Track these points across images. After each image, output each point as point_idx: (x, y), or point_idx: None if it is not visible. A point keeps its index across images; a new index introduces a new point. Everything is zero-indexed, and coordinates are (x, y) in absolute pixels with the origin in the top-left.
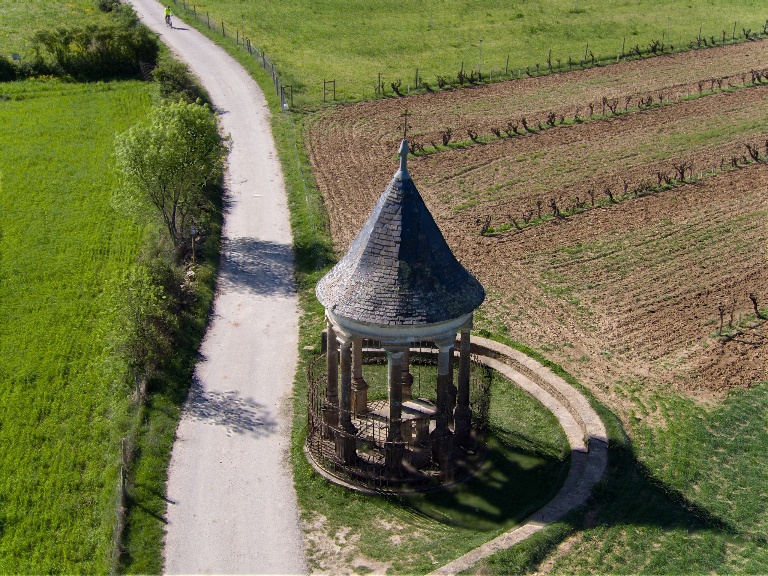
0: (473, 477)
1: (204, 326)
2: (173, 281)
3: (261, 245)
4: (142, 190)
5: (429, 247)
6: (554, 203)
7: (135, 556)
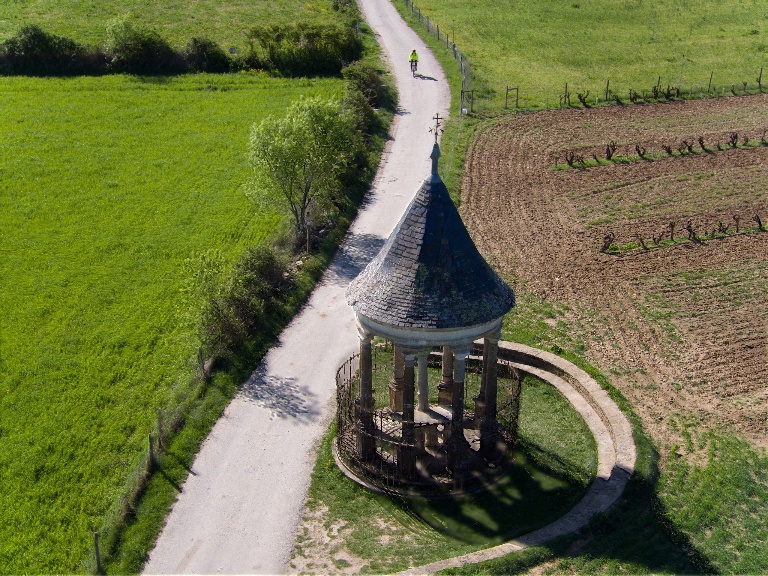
0: (485, 490)
1: (292, 314)
2: (273, 268)
3: (381, 242)
4: (273, 180)
5: (451, 252)
6: (690, 226)
7: (140, 517)
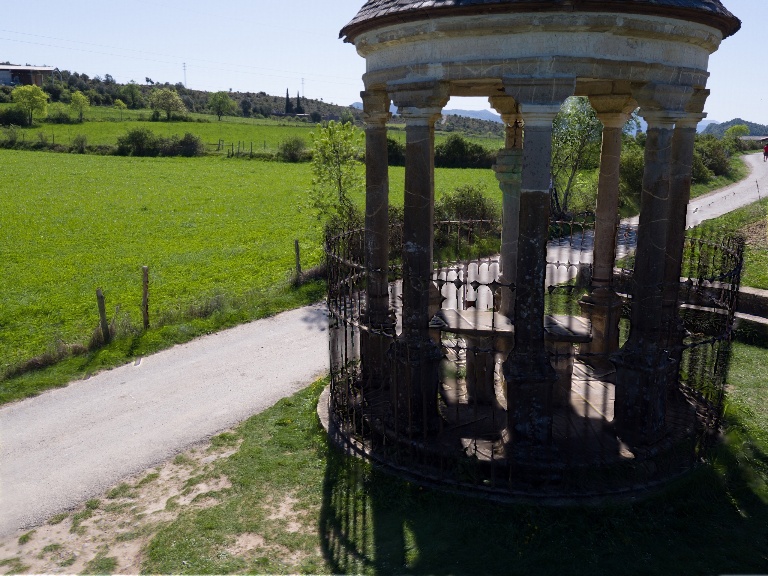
0: (578, 504)
1: (476, 255)
2: (476, 210)
3: None
4: None
5: None
6: None
7: None
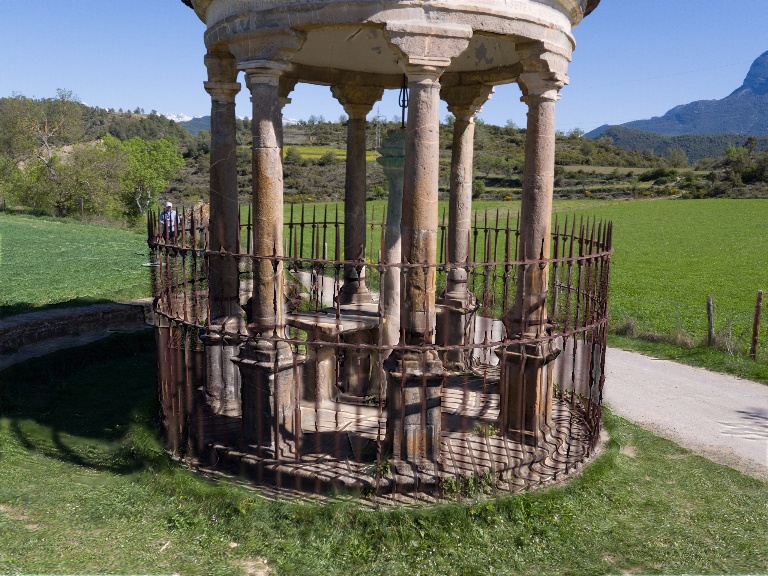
0: None
1: None
2: None
3: None
4: None
5: None
6: None
7: None
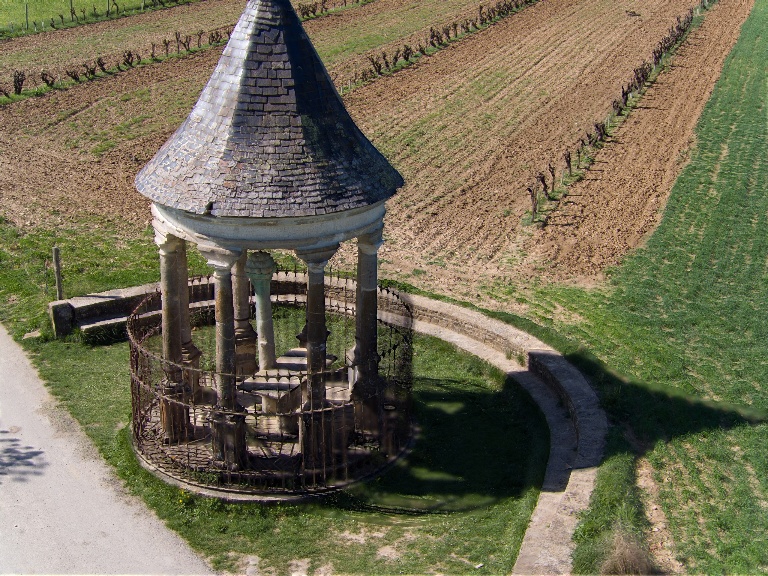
0: (418, 438)
1: None
2: None
3: None
4: None
5: (332, 92)
6: None
7: None
